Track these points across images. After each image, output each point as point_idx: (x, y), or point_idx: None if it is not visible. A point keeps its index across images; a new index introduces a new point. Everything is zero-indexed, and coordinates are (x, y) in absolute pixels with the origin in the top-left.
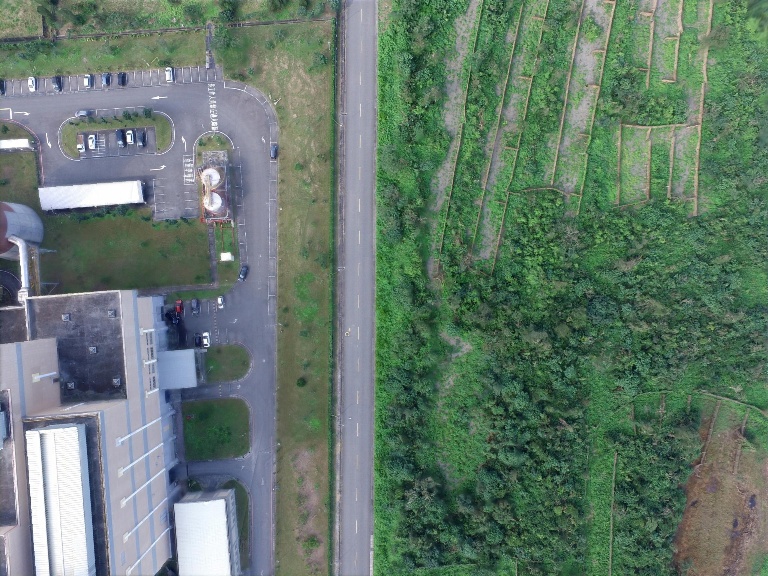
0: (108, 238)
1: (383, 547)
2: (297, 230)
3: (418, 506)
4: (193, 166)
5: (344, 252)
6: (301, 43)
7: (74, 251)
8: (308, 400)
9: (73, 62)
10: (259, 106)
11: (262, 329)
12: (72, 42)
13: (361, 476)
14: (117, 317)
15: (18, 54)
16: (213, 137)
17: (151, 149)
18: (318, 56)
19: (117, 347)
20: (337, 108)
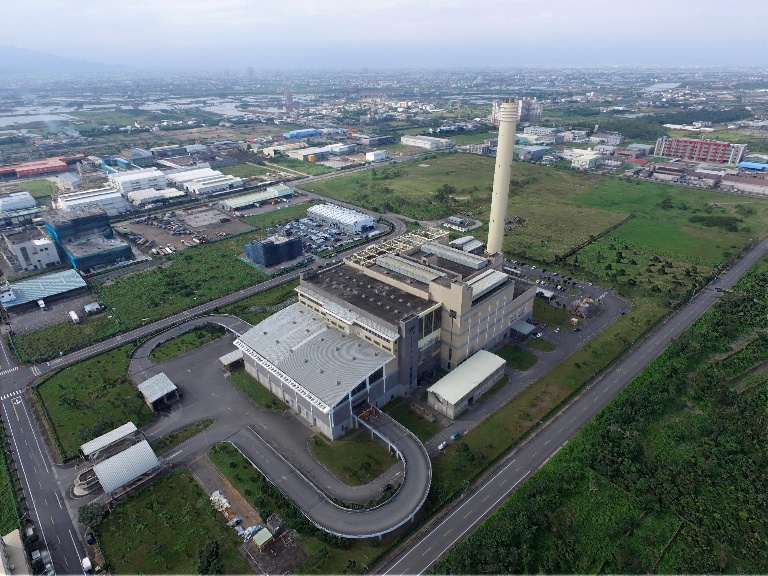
0: None
1: (572, 448)
2: (616, 332)
3: (618, 434)
4: None
5: (637, 349)
6: (659, 300)
7: None
8: (575, 374)
9: (554, 270)
10: None
11: None
12: None
13: (582, 415)
14: (528, 289)
15: None
16: None
17: None
18: None
19: (521, 293)
20: None
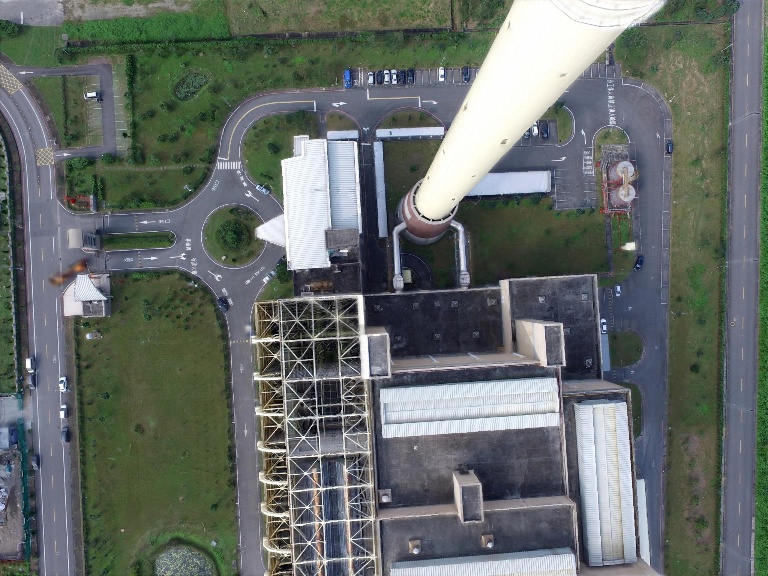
0: (512, 225)
1: (765, 529)
2: (690, 223)
3: None
4: (592, 158)
5: (730, 245)
6: (696, 44)
7: (480, 237)
8: (698, 386)
9: (480, 54)
10: (654, 103)
11: (655, 317)
12: (480, 35)
13: (744, 460)
14: (589, 300)
15: (438, 45)
16: (611, 131)
17: (552, 141)
18: (720, 57)
19: (588, 329)
20: None
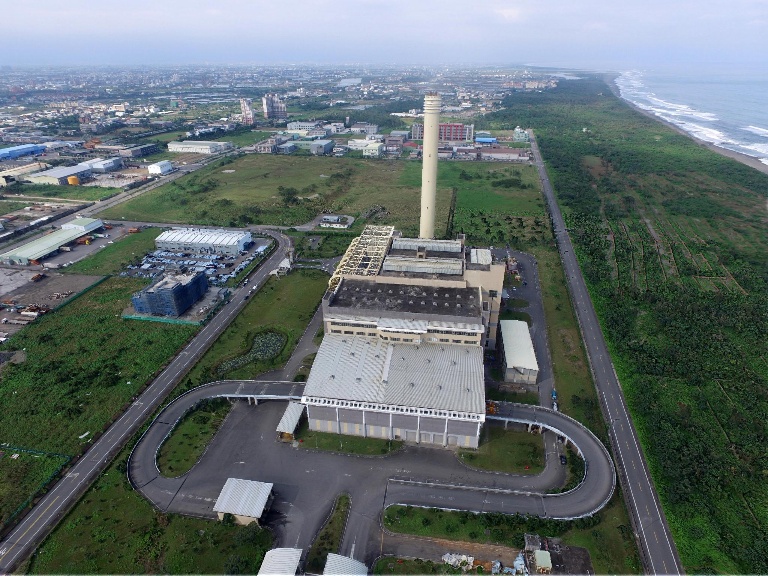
0: None
1: None
2: (548, 277)
3: (638, 344)
4: None
5: (571, 285)
6: (543, 247)
7: None
8: None
9: None
10: None
11: None
12: None
13: (598, 342)
14: None
15: (439, 238)
16: None
17: None
18: None
19: None
20: (560, 258)
